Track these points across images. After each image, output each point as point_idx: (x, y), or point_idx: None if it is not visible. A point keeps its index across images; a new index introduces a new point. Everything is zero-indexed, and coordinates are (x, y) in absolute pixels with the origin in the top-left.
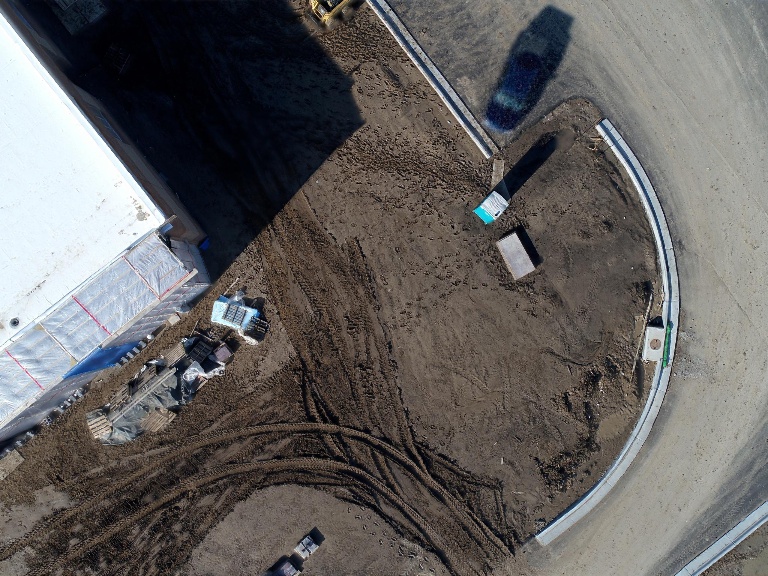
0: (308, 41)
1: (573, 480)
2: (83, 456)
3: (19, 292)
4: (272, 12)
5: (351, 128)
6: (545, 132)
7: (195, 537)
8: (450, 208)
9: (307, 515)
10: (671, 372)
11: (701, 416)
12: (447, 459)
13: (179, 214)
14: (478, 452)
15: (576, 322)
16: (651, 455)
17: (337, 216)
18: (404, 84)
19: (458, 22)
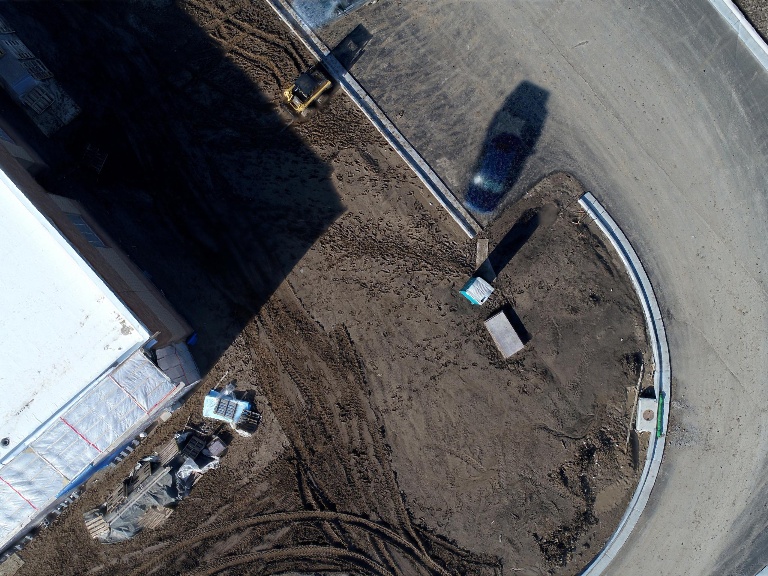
0: (285, 131)
1: (572, 554)
2: (83, 556)
3: (8, 412)
4: (248, 104)
5: (333, 216)
6: (528, 208)
7: None
8: (436, 290)
9: None
10: (665, 441)
11: (697, 484)
12: (445, 540)
13: (164, 318)
14: (476, 531)
15: (568, 396)
16: (649, 525)
17: (323, 304)
18: (384, 168)
19: (435, 103)
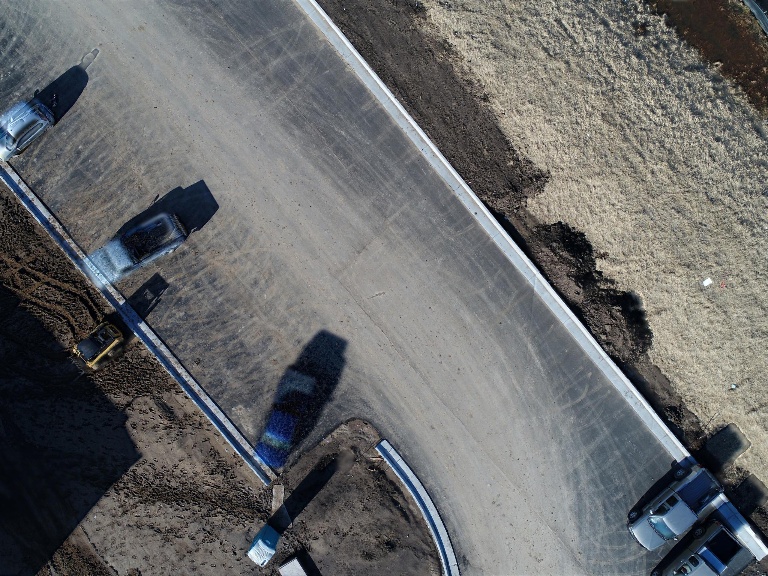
0: (79, 380)
1: None
2: None
3: None
4: (41, 353)
5: (127, 463)
6: (325, 455)
7: None
8: (231, 535)
9: None
10: None
11: None
12: None
13: None
14: None
15: None
16: None
17: (117, 549)
18: (179, 416)
19: (231, 352)
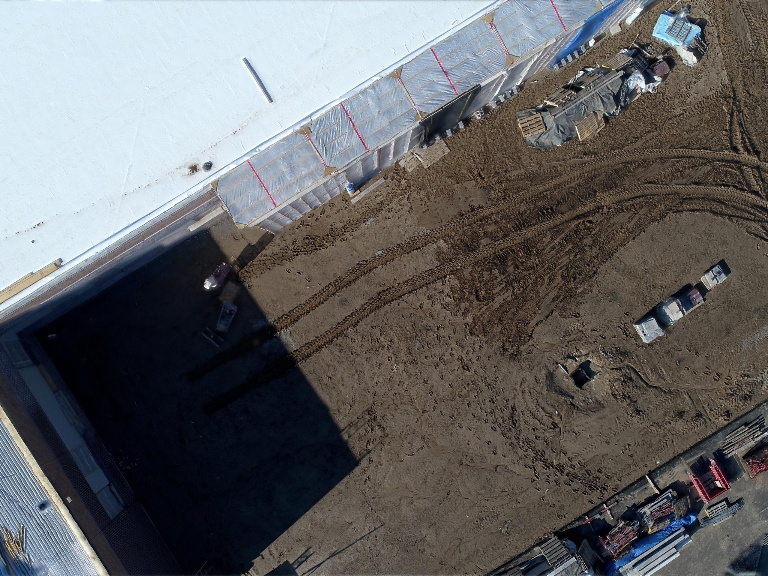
0: None
1: None
2: (507, 156)
3: None
4: None
5: None
6: None
7: (603, 254)
8: None
9: (716, 246)
10: None
11: None
12: None
13: None
14: None
15: None
16: None
17: None
18: None
19: None
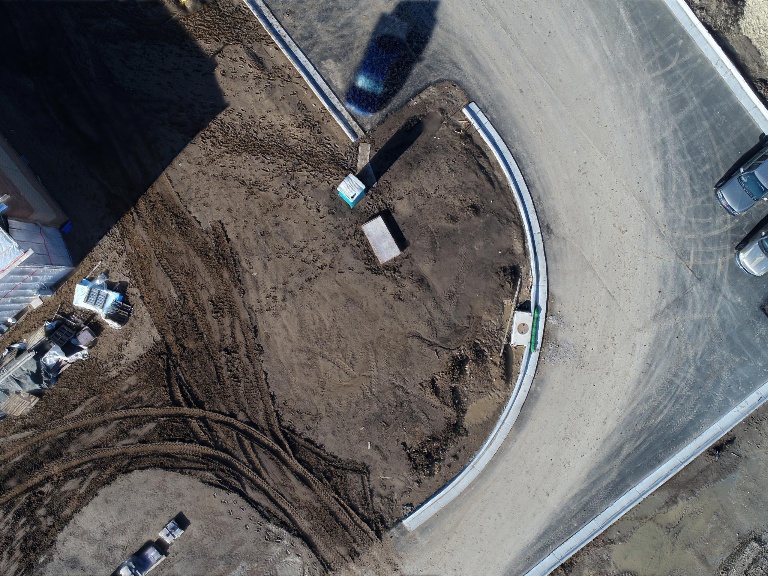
0: (170, 23)
1: (441, 465)
2: None
3: None
4: None
5: (214, 111)
6: (412, 115)
7: (60, 522)
8: (315, 191)
9: (172, 500)
10: (539, 356)
11: (569, 401)
12: (313, 444)
13: (30, 196)
14: (345, 437)
15: (443, 306)
16: (519, 440)
17: (201, 199)
18: (268, 67)
19: (323, 5)
